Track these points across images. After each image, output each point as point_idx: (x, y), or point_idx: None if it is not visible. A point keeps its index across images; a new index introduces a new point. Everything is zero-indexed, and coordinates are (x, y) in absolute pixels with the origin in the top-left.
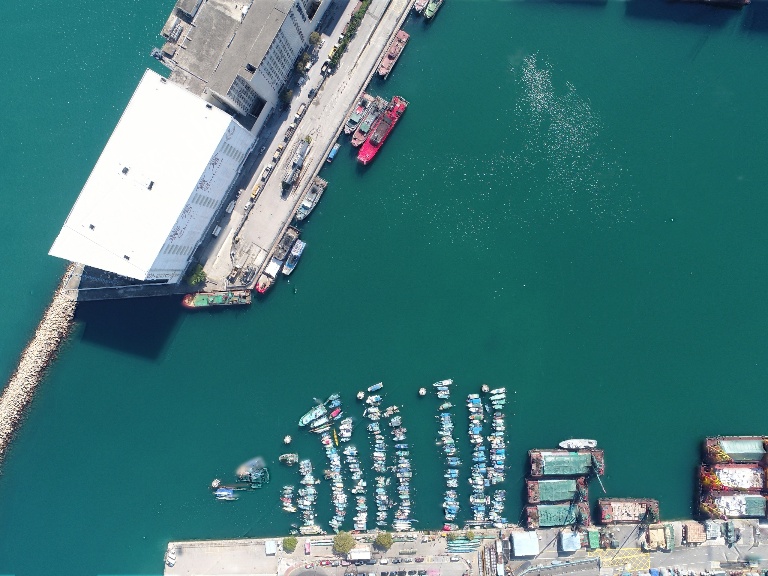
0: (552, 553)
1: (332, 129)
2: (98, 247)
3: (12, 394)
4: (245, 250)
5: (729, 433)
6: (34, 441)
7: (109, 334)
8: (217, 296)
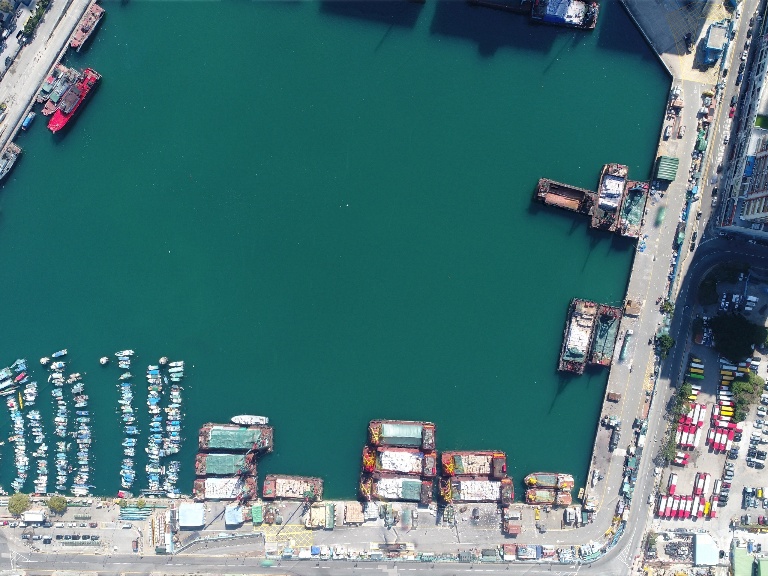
0: (220, 525)
1: (27, 97)
2: None
3: None
4: None
5: (393, 417)
6: None
7: None
8: None
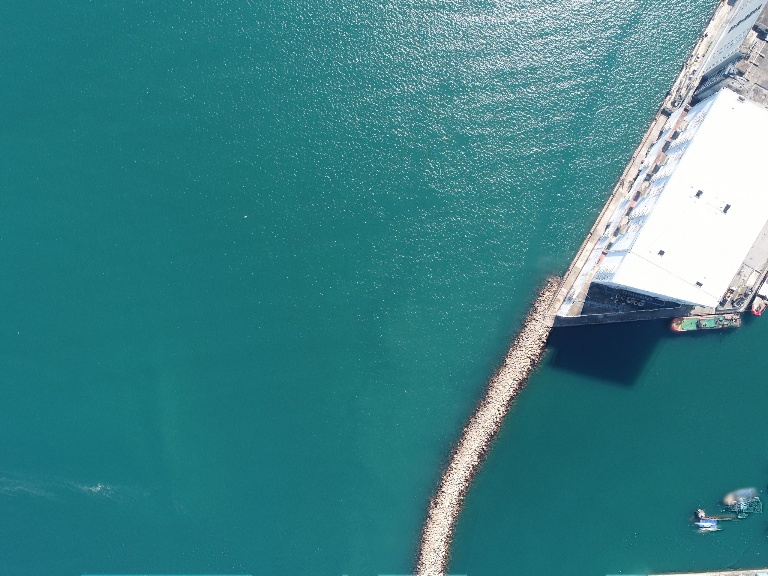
0: None
1: None
2: (667, 274)
3: (484, 425)
4: None
5: None
6: (497, 473)
7: (583, 360)
8: (710, 320)
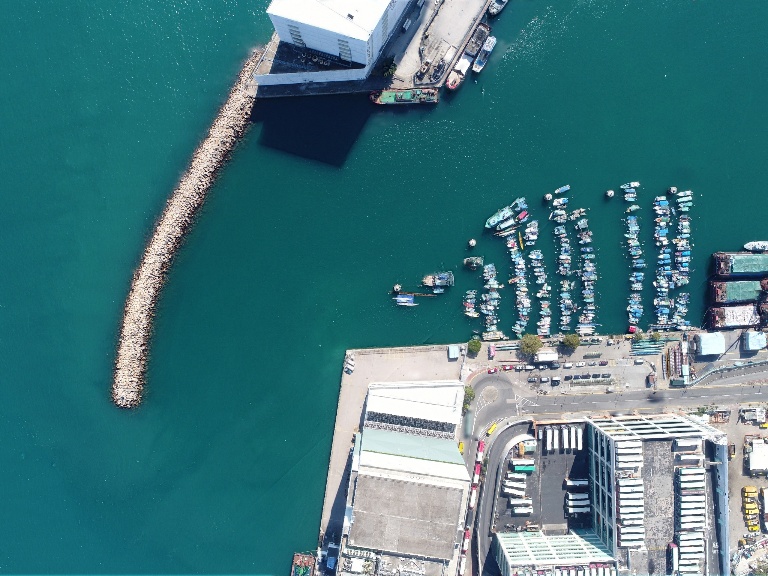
0: (734, 355)
1: None
2: (320, 5)
3: (185, 194)
4: (434, 46)
5: None
6: (203, 248)
7: (287, 134)
8: (406, 92)
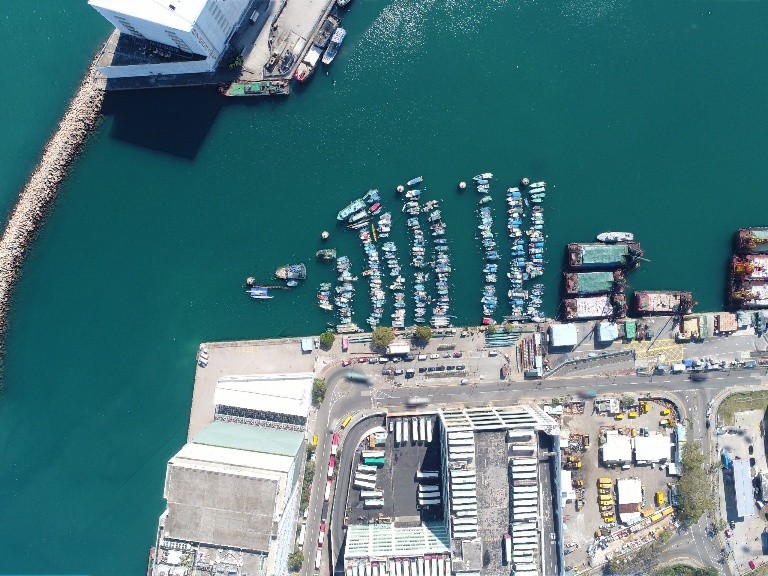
0: (589, 346)
1: None
2: None
3: (35, 187)
4: (283, 38)
5: (760, 225)
6: (57, 241)
7: (139, 127)
8: (254, 84)
